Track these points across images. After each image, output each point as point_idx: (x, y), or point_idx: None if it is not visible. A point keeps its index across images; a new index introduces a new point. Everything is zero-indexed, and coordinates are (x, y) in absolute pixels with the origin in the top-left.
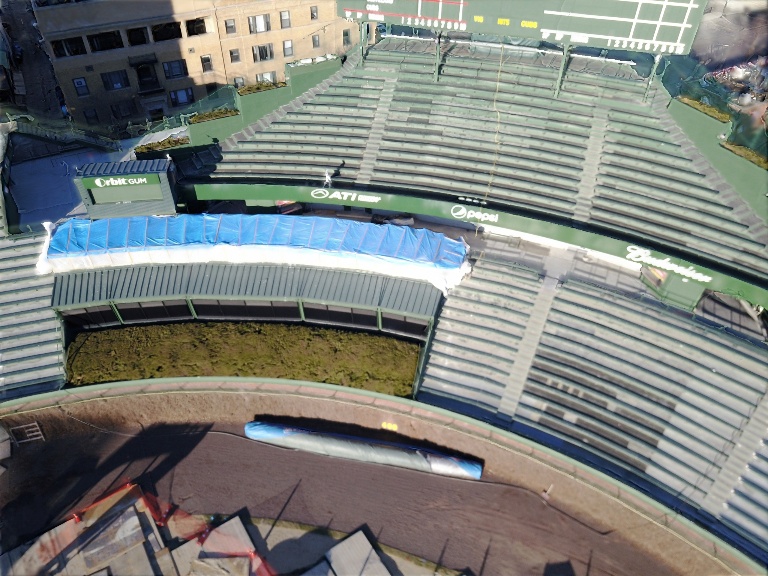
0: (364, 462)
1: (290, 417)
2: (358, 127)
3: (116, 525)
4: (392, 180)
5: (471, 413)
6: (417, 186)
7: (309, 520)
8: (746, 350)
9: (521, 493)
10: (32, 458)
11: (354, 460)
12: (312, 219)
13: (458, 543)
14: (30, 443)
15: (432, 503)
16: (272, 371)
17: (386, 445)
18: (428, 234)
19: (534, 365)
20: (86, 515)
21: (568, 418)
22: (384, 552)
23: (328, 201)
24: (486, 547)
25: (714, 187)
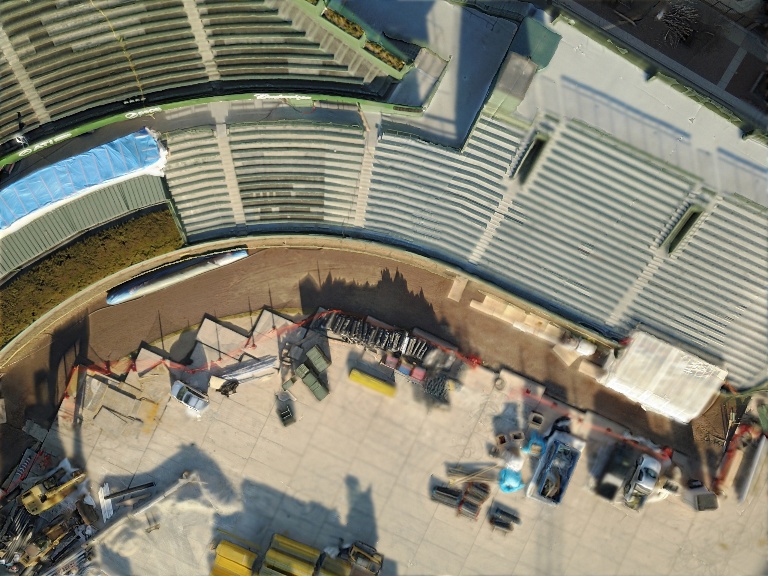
0: (184, 281)
1: (126, 281)
2: (3, 79)
3: (88, 388)
4: (66, 108)
5: (223, 232)
6: (88, 106)
7: (177, 328)
8: (347, 131)
9: (273, 250)
10: (10, 386)
11: (178, 283)
12: (37, 175)
13: (254, 296)
14: (0, 380)
15: (231, 283)
16: (98, 277)
17: (190, 267)
18: (123, 143)
19: (241, 189)
20: (69, 393)
21: (274, 210)
22: (222, 321)
23: (35, 151)
24: (268, 290)
25: (287, 18)
